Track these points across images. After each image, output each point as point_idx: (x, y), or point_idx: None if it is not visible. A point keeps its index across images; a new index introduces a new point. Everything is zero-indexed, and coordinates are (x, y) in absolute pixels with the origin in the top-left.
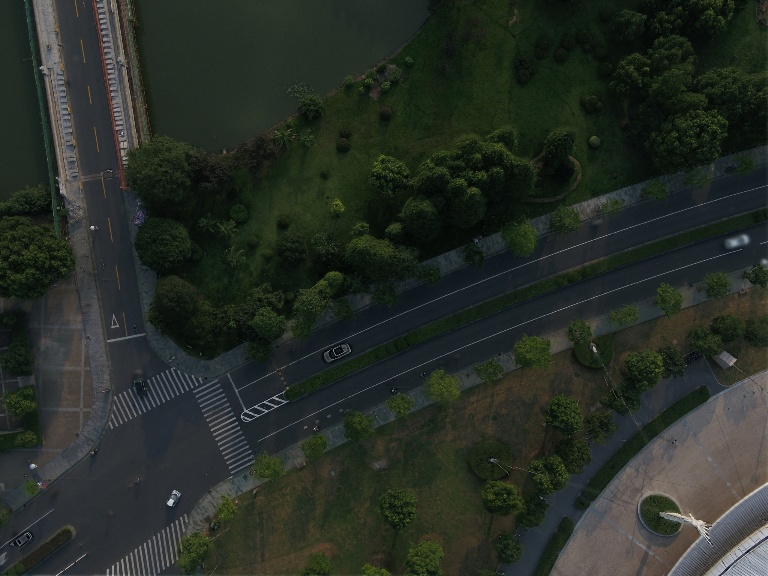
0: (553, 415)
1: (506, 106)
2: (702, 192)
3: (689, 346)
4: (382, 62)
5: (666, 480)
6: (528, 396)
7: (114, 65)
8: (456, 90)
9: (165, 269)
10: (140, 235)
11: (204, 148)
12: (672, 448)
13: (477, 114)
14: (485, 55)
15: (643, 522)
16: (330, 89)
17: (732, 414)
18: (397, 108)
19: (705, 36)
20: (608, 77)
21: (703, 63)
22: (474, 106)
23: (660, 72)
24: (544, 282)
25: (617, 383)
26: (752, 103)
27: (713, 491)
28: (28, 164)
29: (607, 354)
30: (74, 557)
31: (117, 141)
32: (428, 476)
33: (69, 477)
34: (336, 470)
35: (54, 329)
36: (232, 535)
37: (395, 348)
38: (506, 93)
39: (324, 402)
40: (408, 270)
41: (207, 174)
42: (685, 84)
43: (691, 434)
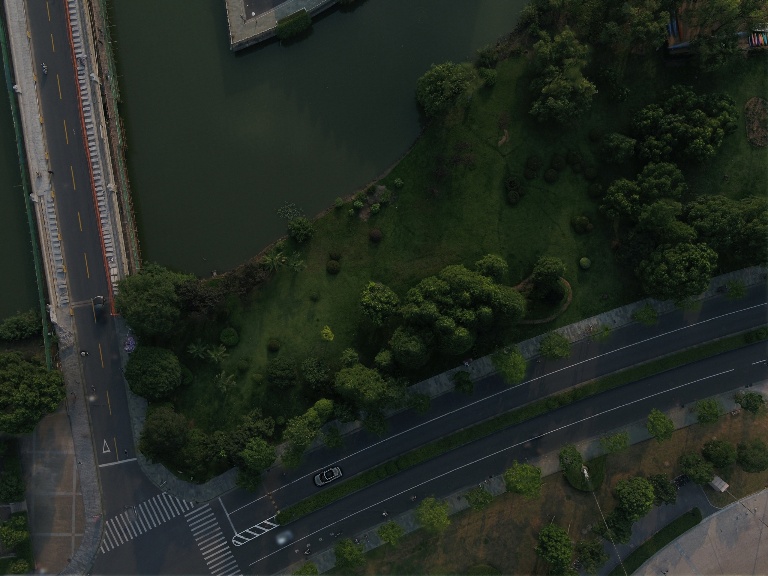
0: (544, 547)
1: (496, 227)
2: (693, 312)
3: None
4: (372, 183)
5: None
6: (519, 519)
7: (104, 192)
8: (446, 211)
9: (155, 398)
10: (130, 366)
11: (194, 274)
12: (665, 570)
13: (467, 235)
14: (475, 175)
15: None
16: (320, 210)
17: (725, 536)
18: (387, 229)
19: (695, 160)
20: (598, 198)
21: (694, 182)
22: (464, 227)
23: (649, 200)
24: (535, 405)
25: (609, 506)
26: (742, 233)
27: None
28: (19, 291)
29: (598, 477)
30: None
31: (107, 267)
32: None
33: None
34: None
35: (46, 454)
36: None
37: (386, 472)
38: (496, 214)
39: (315, 525)
40: None
41: (197, 303)
42: None
43: (684, 556)
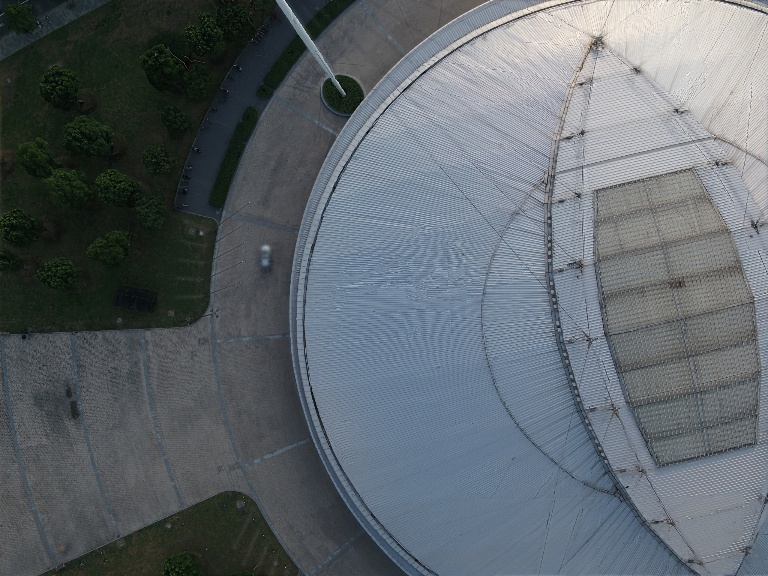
0: None
1: None
2: None
3: None
4: None
5: (348, 62)
6: None
7: None
8: None
9: None
10: None
11: None
12: (351, 30)
13: None
14: None
15: (326, 104)
16: None
17: None
18: None
19: None
20: None
21: None
22: None
23: None
24: None
25: None
26: None
27: None
28: None
29: None
30: None
31: None
32: (105, 75)
33: None
34: (12, 77)
35: None
36: None
37: None
38: None
39: None
40: None
41: None
42: None
43: (369, 15)
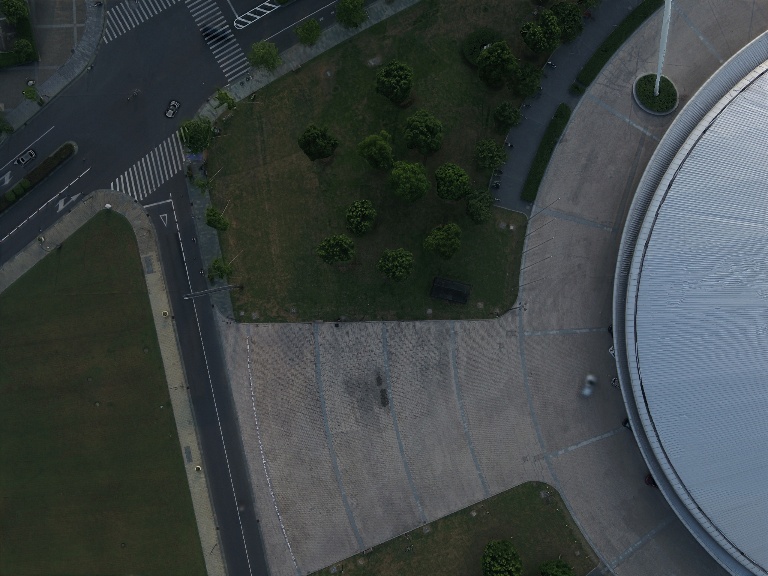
0: None
1: None
2: None
3: None
4: None
5: None
6: None
7: None
8: None
9: None
10: None
11: None
12: None
13: None
14: None
15: (639, 102)
16: None
17: None
18: None
19: None
20: None
21: None
22: None
23: None
24: None
25: None
26: None
27: (706, 69)
28: None
29: None
30: (78, 172)
31: None
32: (423, 70)
33: (67, 94)
34: (332, 70)
35: None
36: (233, 141)
37: None
38: None
39: (315, 5)
40: None
41: None
42: None
43: (681, 15)
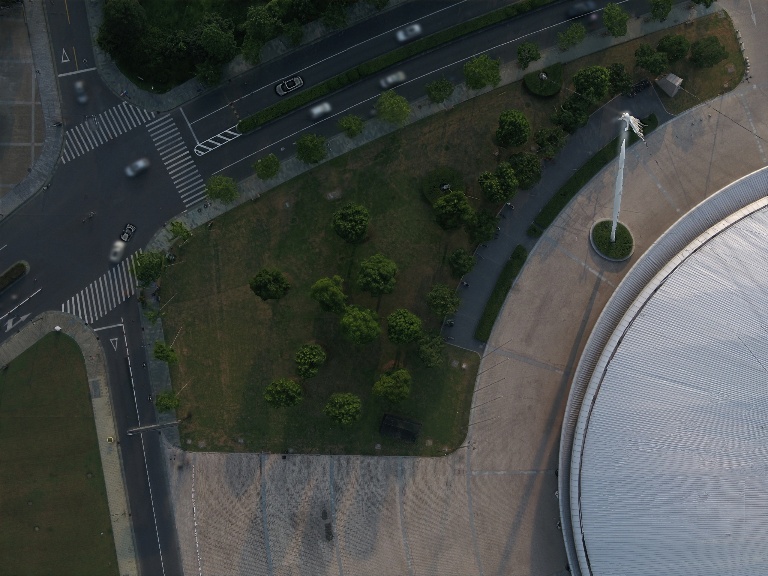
0: (502, 126)
1: None
2: None
3: (637, 76)
4: None
5: None
6: (480, 126)
7: None
8: None
9: None
10: None
11: None
12: None
13: None
14: None
15: (595, 248)
16: None
17: (680, 142)
18: None
19: None
20: None
21: None
22: None
23: None
24: (493, 12)
25: None
26: None
27: (663, 217)
28: None
29: (557, 82)
30: (28, 292)
31: None
32: (382, 205)
33: (22, 213)
34: (290, 201)
35: (3, 63)
36: (188, 268)
37: (347, 78)
38: None
39: (277, 135)
40: (358, 2)
41: None
42: None
43: (641, 162)
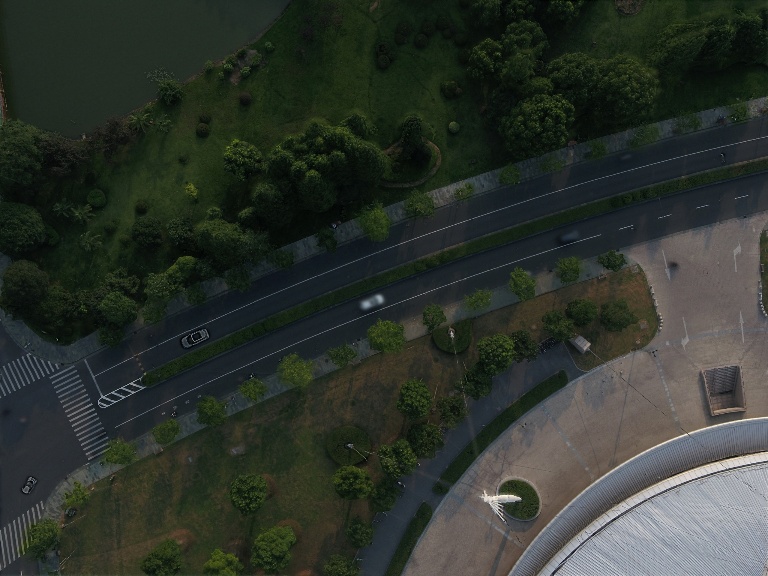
0: (402, 399)
1: (366, 92)
2: (561, 178)
3: None
4: (243, 47)
5: (525, 465)
6: (387, 381)
7: None
8: (316, 75)
9: (16, 254)
10: None
11: (59, 132)
12: (531, 433)
13: (337, 99)
14: (346, 41)
15: None
16: (191, 74)
17: (591, 399)
18: (257, 93)
19: (559, 22)
20: (467, 63)
21: (562, 49)
22: (334, 91)
23: (511, 57)
24: (402, 267)
25: None
26: (599, 88)
27: (571, 476)
28: None
29: (465, 339)
30: None
31: None
32: (286, 462)
33: None
34: (193, 456)
35: None
36: (88, 522)
37: (252, 333)
38: (366, 79)
39: (182, 388)
40: (266, 255)
41: (58, 158)
42: (535, 69)
43: (550, 419)
